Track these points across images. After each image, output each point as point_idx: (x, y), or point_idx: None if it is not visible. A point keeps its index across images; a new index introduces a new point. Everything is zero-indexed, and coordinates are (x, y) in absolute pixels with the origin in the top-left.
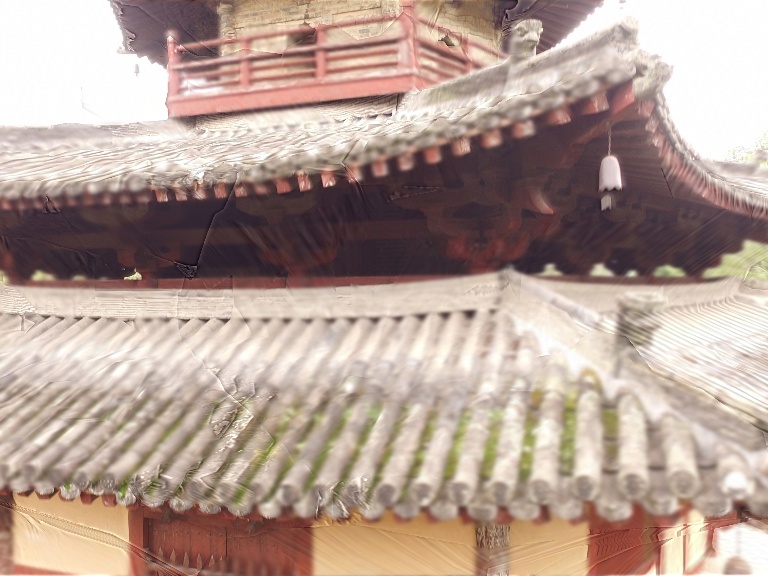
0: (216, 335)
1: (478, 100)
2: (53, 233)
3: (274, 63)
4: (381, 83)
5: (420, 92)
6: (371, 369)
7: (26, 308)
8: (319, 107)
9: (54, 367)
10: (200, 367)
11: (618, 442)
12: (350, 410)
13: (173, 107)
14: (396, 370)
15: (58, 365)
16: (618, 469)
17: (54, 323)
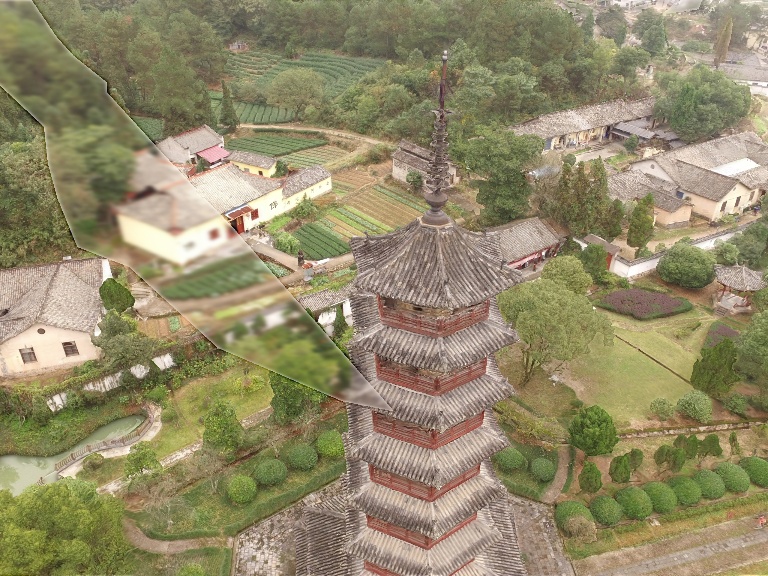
0: None
1: None
2: None
3: None
4: None
5: (356, 575)
6: None
7: None
8: None
9: None
10: None
11: None
12: None
13: None
14: None
15: None
16: None
17: None
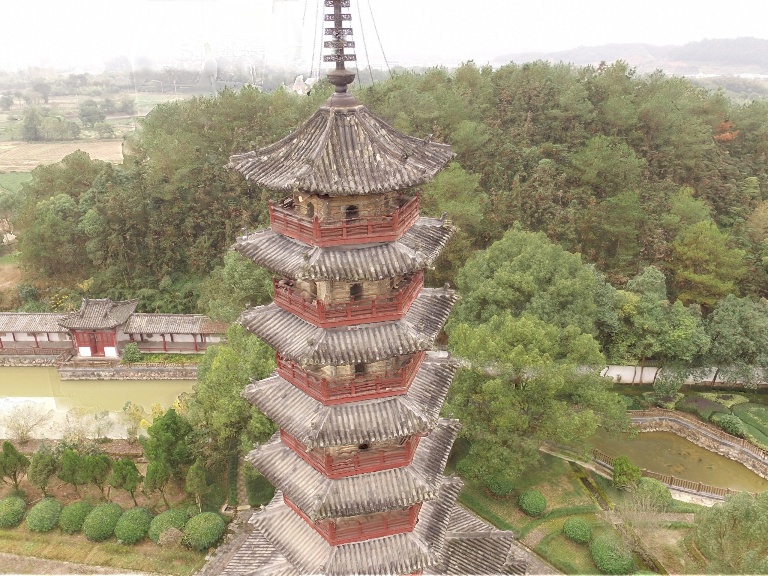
0: None
1: None
2: None
3: None
4: None
5: None
6: None
7: None
8: None
9: None
10: None
11: (518, 568)
12: None
13: None
14: None
15: None
16: (522, 570)
17: None
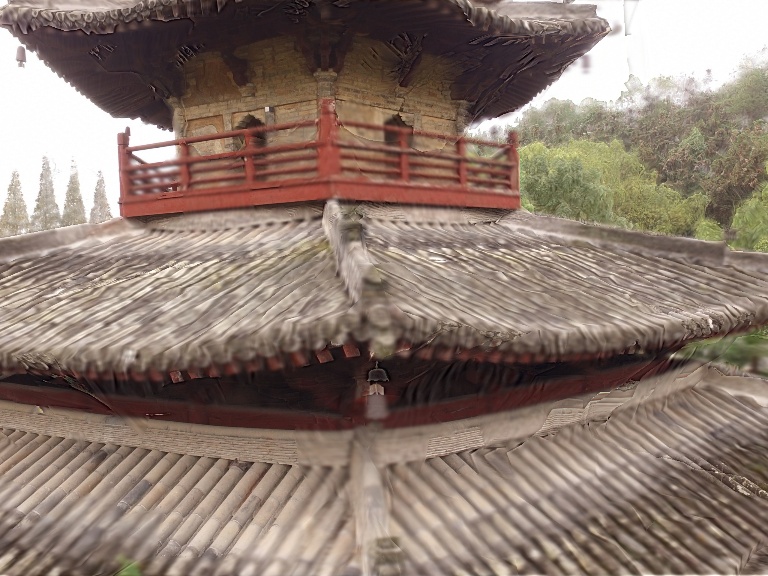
0: (611, 431)
1: (687, 257)
2: (605, 370)
3: (427, 161)
4: (505, 199)
5: (556, 219)
6: (719, 431)
7: (462, 447)
8: (463, 210)
9: (582, 494)
10: (656, 458)
11: None
12: (767, 457)
13: (339, 187)
14: (730, 429)
15: (580, 491)
16: None
17: (482, 456)
